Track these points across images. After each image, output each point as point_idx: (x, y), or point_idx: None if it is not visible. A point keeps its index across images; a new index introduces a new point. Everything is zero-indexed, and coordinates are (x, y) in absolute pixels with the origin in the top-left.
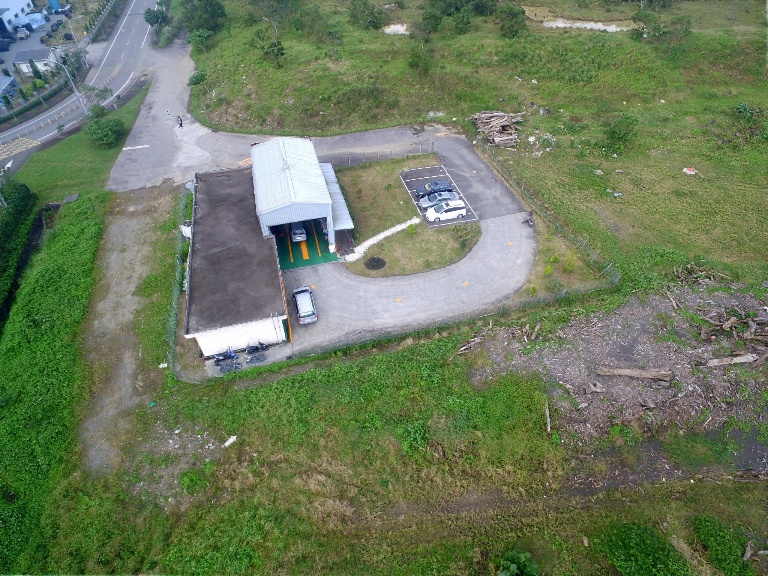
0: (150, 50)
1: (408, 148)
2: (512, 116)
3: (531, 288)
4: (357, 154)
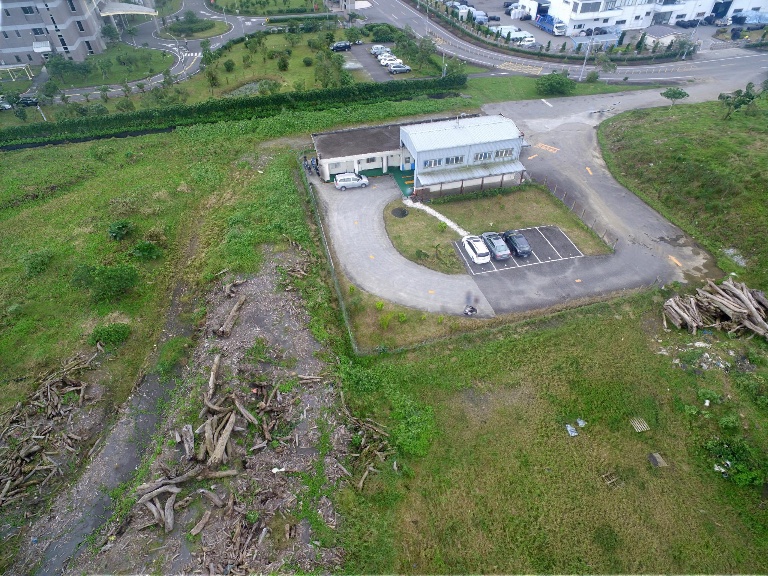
0: (760, 72)
1: (618, 233)
2: (759, 320)
3: None
4: (585, 199)
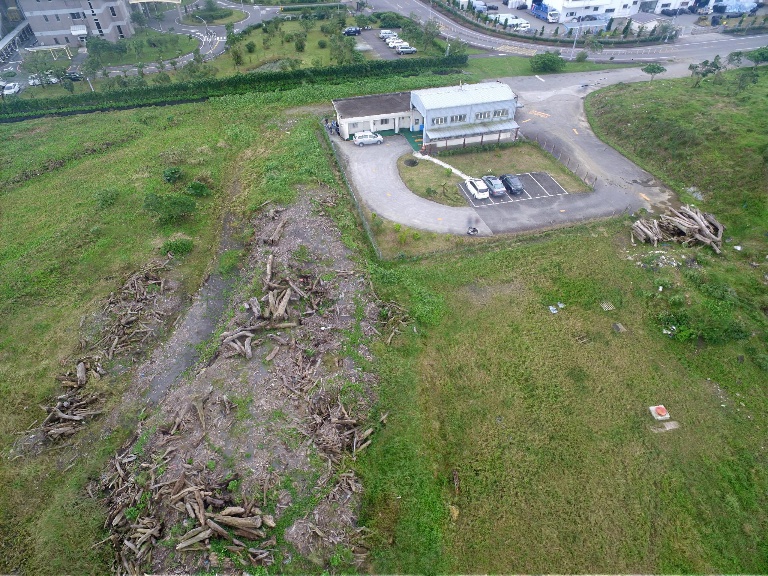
0: None
1: (598, 177)
2: None
3: None
4: (571, 153)
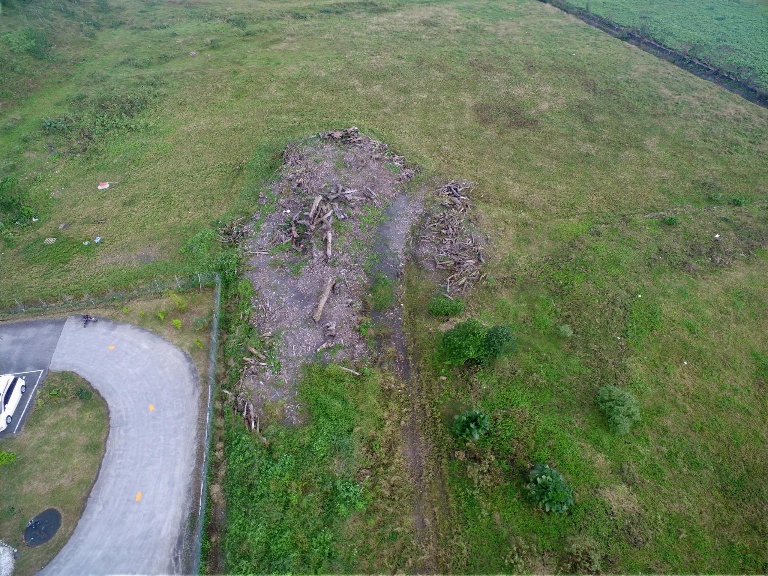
0: None
1: None
2: None
3: (197, 343)
4: None
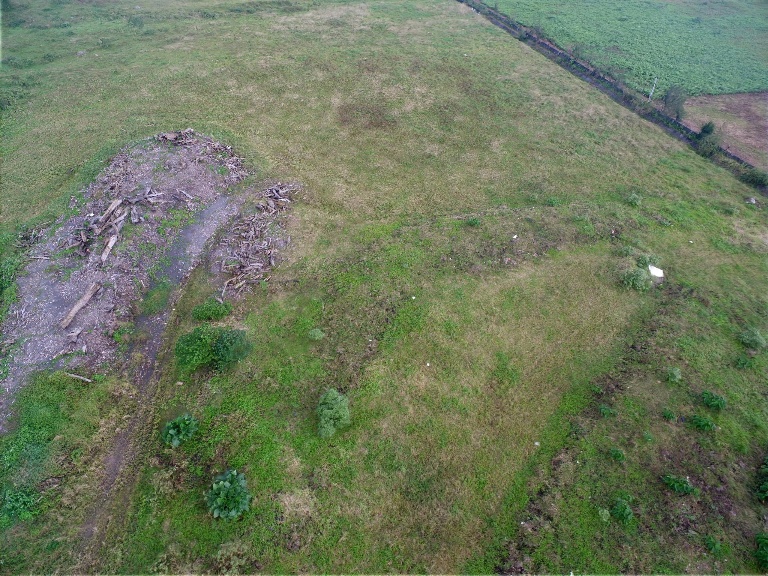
0: None
1: None
2: None
3: None
4: None
